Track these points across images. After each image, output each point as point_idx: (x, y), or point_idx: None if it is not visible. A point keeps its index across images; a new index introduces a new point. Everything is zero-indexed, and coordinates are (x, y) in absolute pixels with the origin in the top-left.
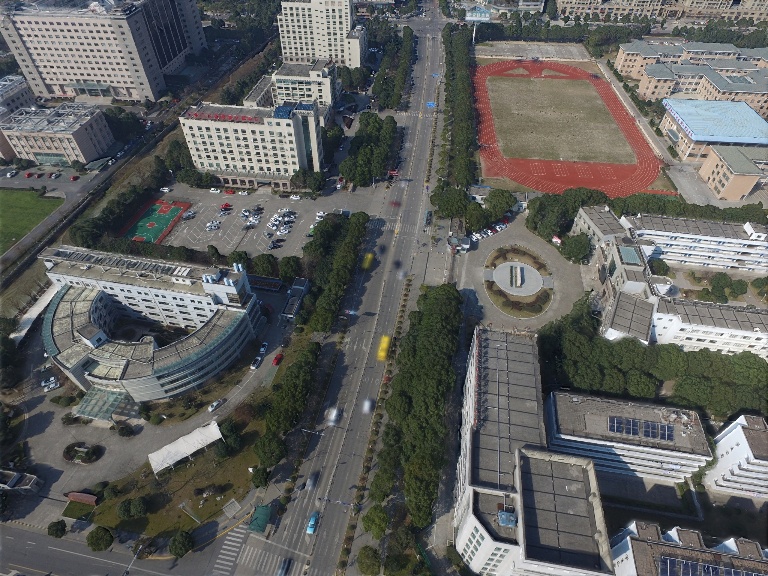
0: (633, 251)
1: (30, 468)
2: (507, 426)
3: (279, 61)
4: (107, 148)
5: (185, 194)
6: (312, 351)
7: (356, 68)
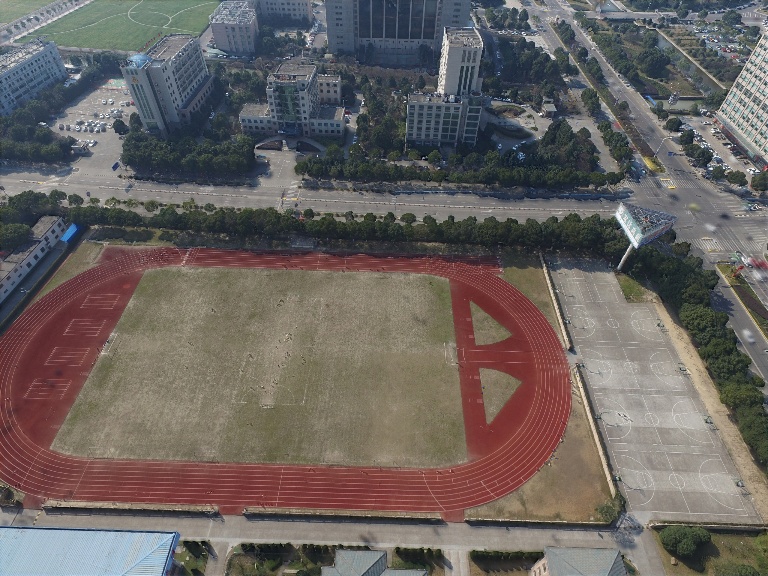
0: None
1: None
2: None
3: (407, 85)
4: (243, 51)
5: None
6: None
7: (380, 127)
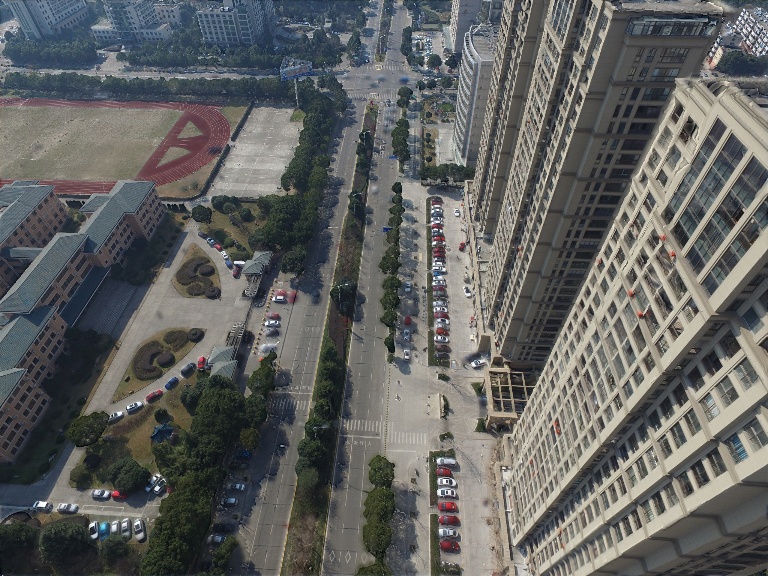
0: None
1: None
2: None
3: None
4: None
5: None
6: None
7: (184, 33)
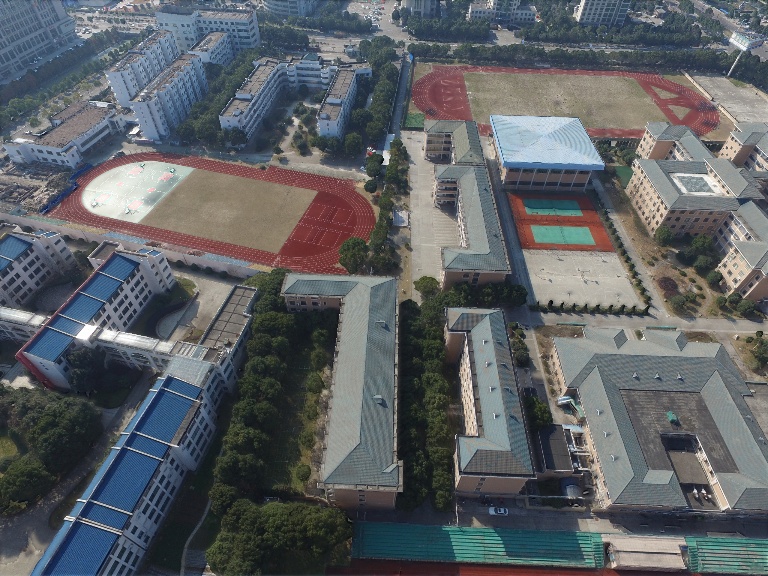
0: None
1: (246, 0)
2: None
3: None
4: None
5: (392, 1)
6: (274, 17)
7: (564, 14)
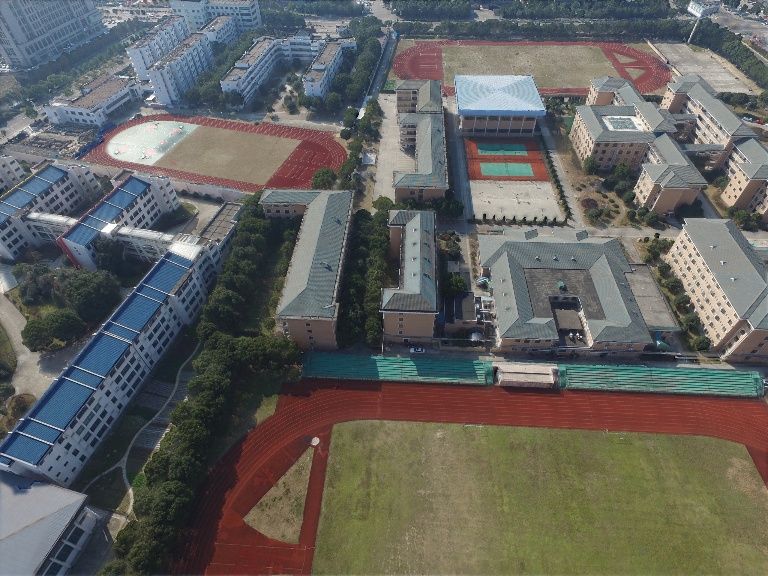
0: (301, 30)
1: None
2: (217, 0)
3: None
4: None
5: None
6: (275, 4)
7: None
